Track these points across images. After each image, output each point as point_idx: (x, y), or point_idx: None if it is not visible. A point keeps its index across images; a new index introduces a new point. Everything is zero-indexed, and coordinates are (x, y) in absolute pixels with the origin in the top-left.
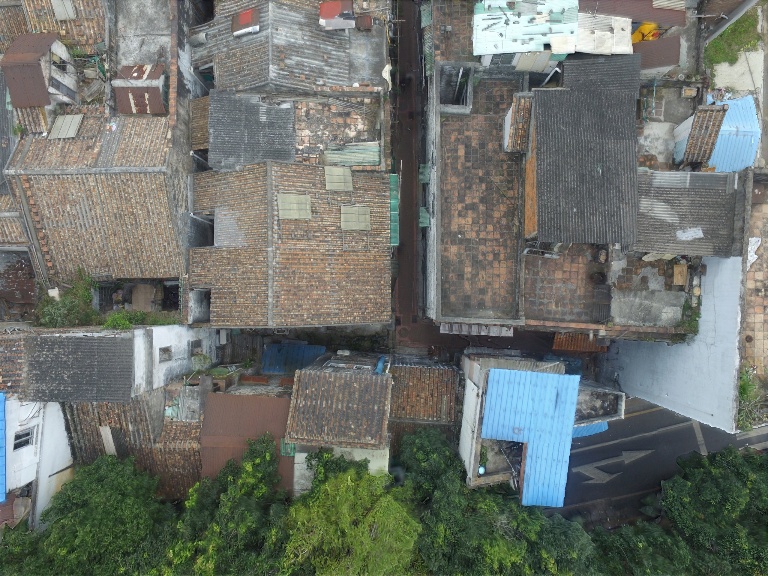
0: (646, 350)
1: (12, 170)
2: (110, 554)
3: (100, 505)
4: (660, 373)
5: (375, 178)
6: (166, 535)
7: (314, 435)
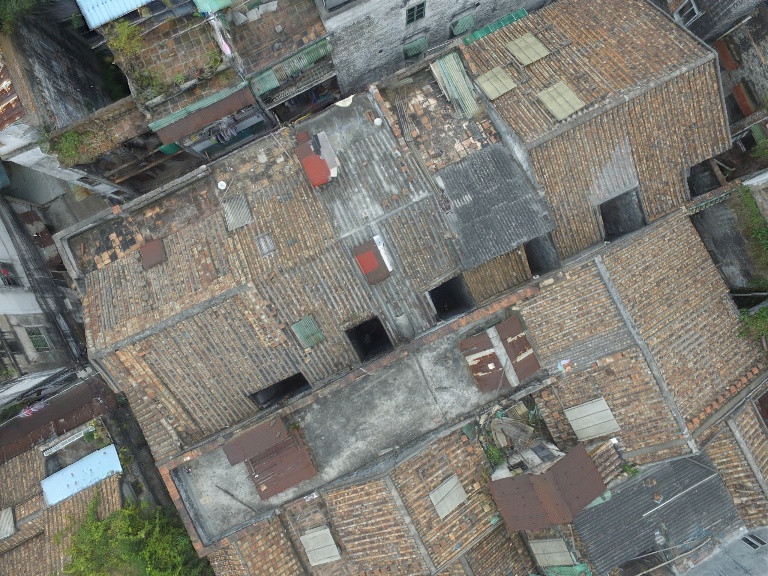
0: None
1: (690, 445)
2: None
3: None
4: None
5: None
6: None
7: None
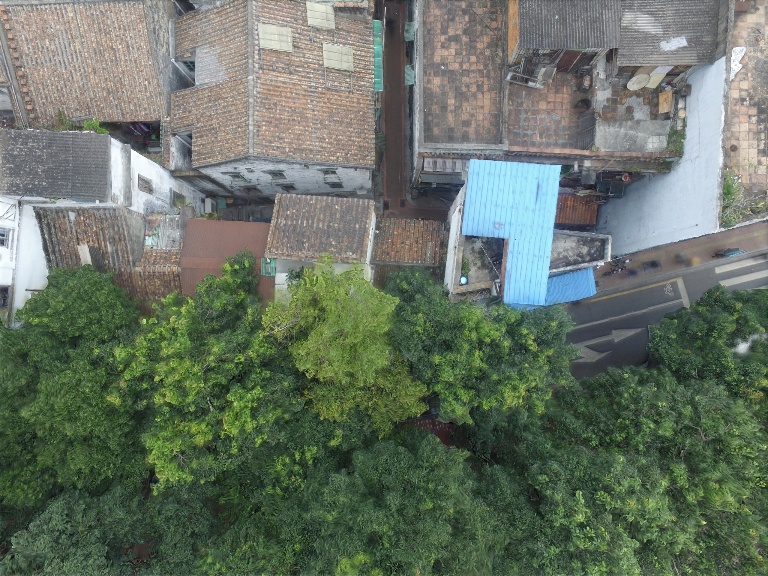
0: (633, 202)
1: None
2: (85, 342)
3: (74, 290)
4: (647, 216)
5: (358, 22)
6: (142, 329)
7: (294, 251)
